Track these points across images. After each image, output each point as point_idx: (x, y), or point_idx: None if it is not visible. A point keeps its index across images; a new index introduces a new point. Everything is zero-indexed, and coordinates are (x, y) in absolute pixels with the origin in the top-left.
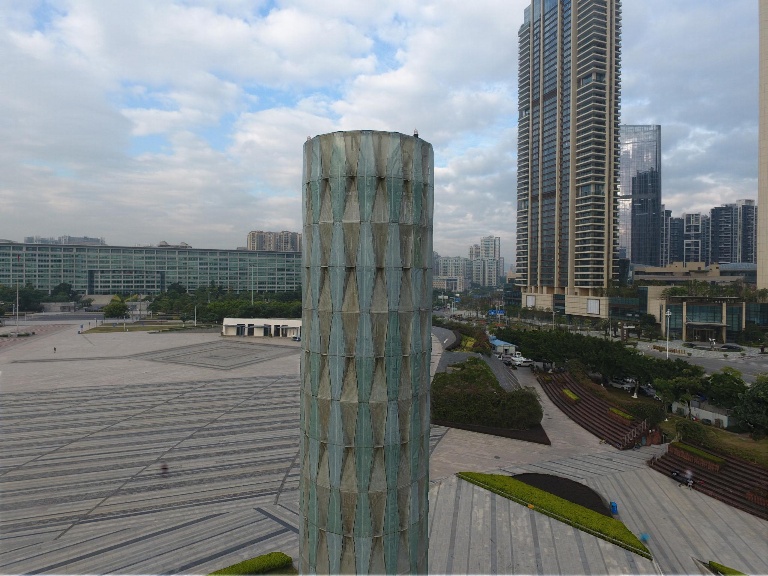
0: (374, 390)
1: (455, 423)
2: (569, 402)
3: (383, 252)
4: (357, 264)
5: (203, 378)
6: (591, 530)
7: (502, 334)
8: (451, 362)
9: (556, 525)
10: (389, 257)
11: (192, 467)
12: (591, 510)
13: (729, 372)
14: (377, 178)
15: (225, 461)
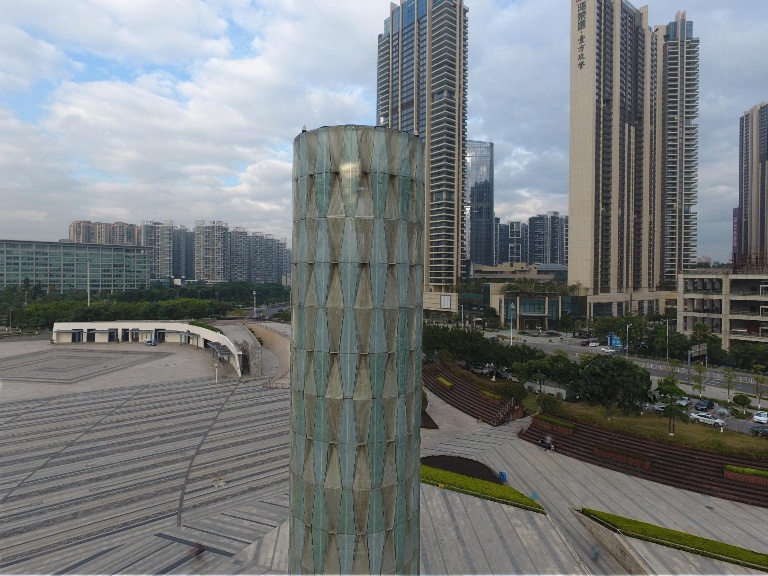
0: (386, 385)
1: None
2: (444, 389)
3: (394, 249)
4: (371, 260)
5: (41, 395)
6: (495, 498)
7: None
8: None
9: (466, 499)
10: (398, 254)
11: (58, 501)
12: (487, 481)
13: None
14: (389, 175)
15: (101, 488)
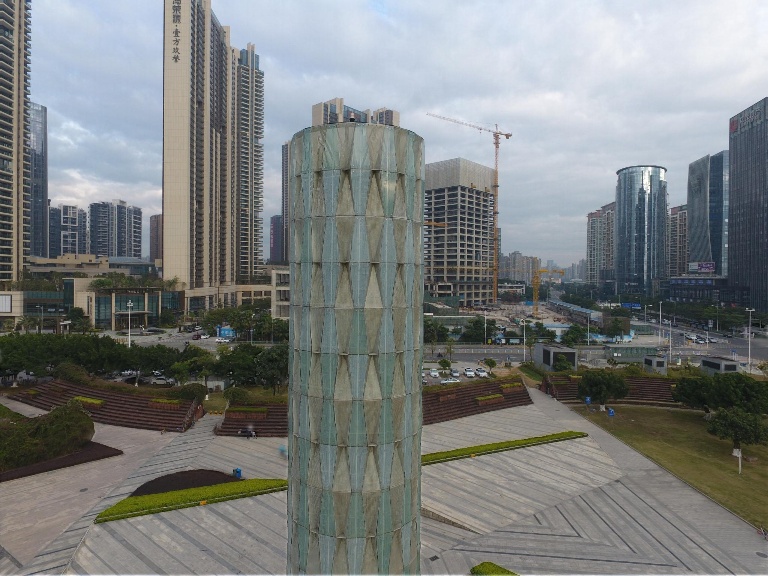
0: None
1: None
2: (92, 408)
3: None
4: None
5: None
6: (263, 491)
7: None
8: None
9: (236, 504)
10: None
11: None
12: None
13: None
14: None
15: None
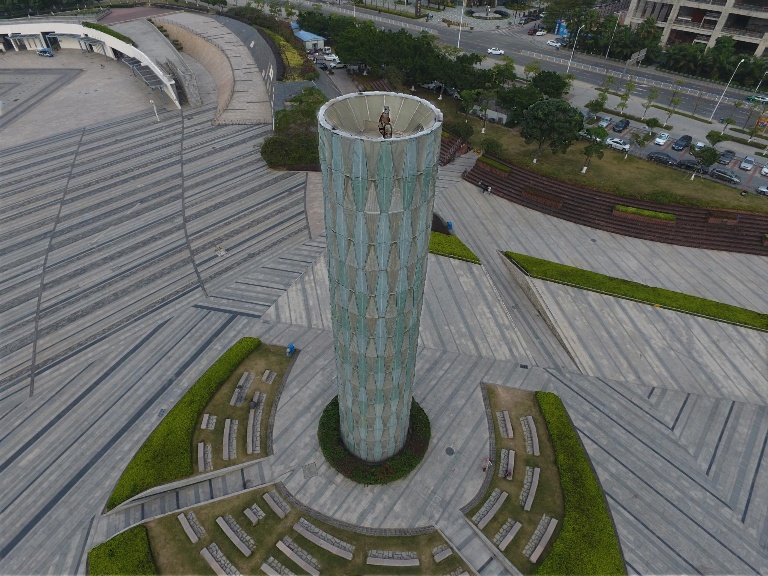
0: (406, 305)
1: (310, 165)
2: None
3: (417, 225)
4: (400, 240)
5: None
6: (446, 254)
7: (307, 23)
8: (287, 96)
9: None
10: None
11: (91, 283)
12: (438, 232)
13: (506, 60)
14: (417, 175)
15: (120, 267)
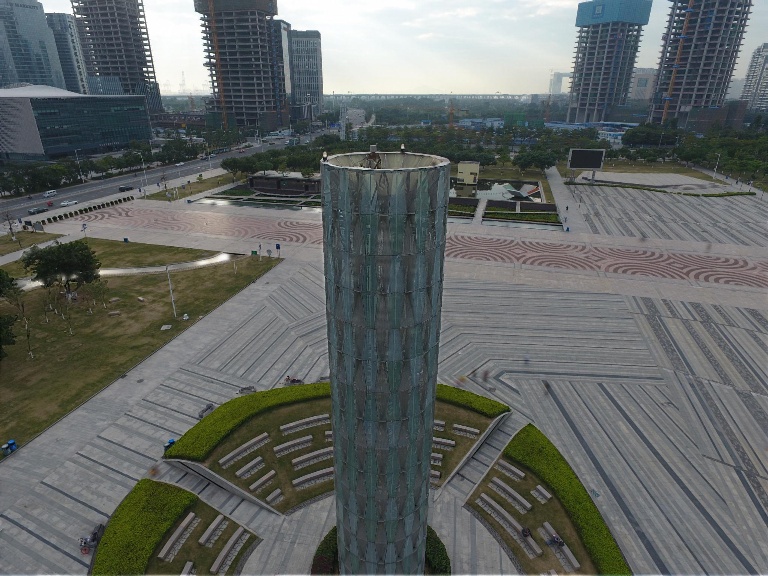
0: None
1: None
2: None
3: None
4: None
5: None
6: None
7: None
8: None
9: None
10: None
11: None
12: None
13: None
14: None
15: None
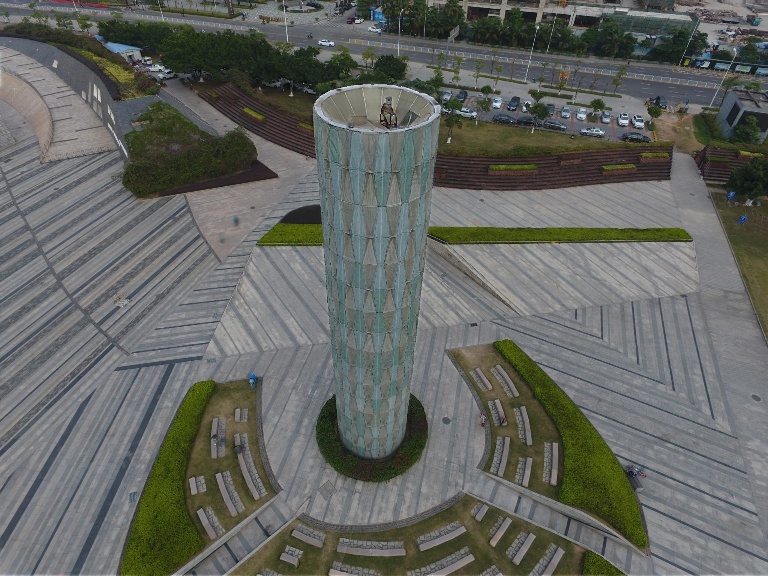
0: None
1: (184, 186)
2: (256, 122)
3: (427, 209)
4: None
5: None
6: None
7: (113, 34)
8: (132, 115)
9: None
10: None
11: None
12: None
13: (341, 50)
14: None
15: None
